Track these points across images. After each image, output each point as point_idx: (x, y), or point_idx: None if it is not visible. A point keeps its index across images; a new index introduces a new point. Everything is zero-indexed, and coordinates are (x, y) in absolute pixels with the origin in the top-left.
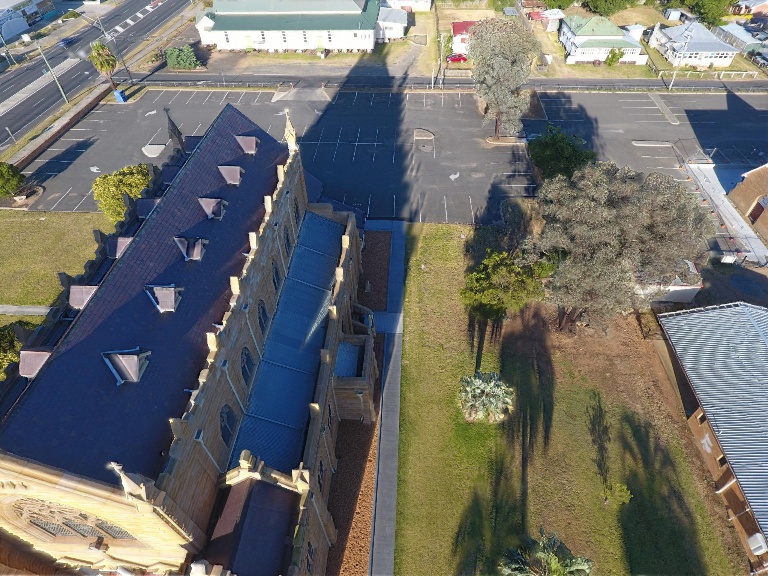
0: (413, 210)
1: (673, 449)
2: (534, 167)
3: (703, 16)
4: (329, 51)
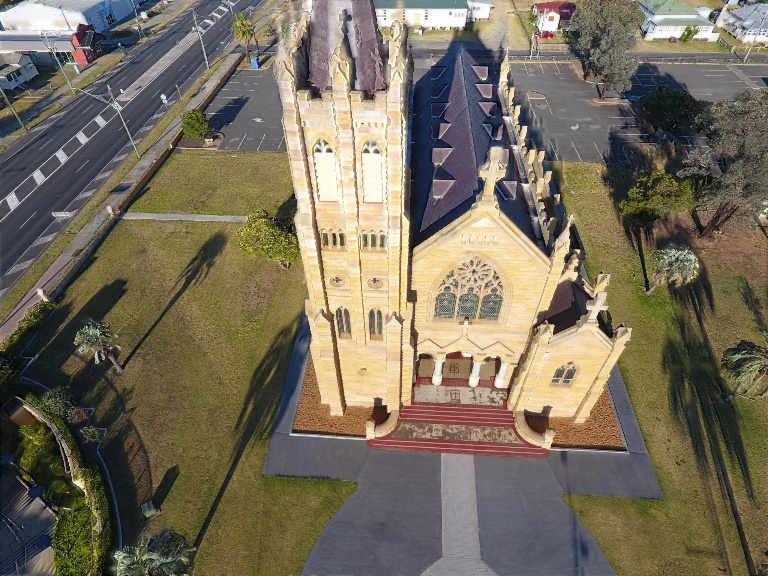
0: (549, 152)
1: None
2: (643, 121)
3: (763, 0)
4: (423, 29)
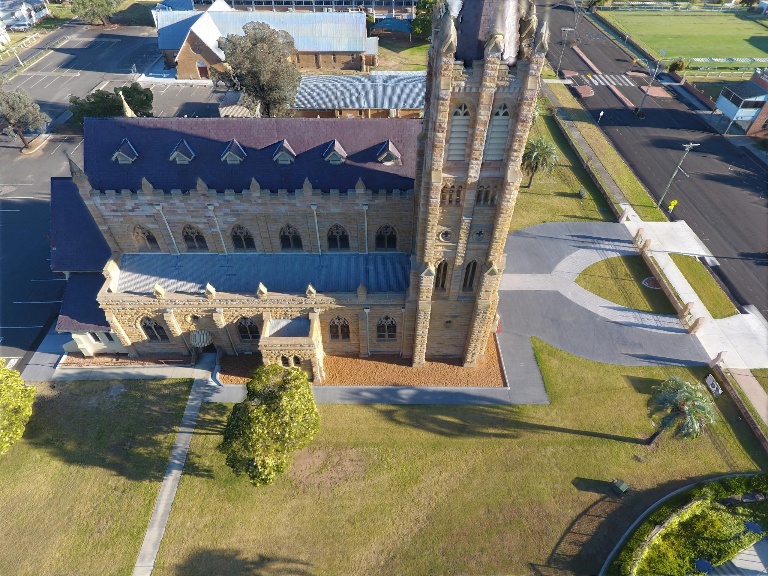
0: None
1: None
2: None
3: None
4: None
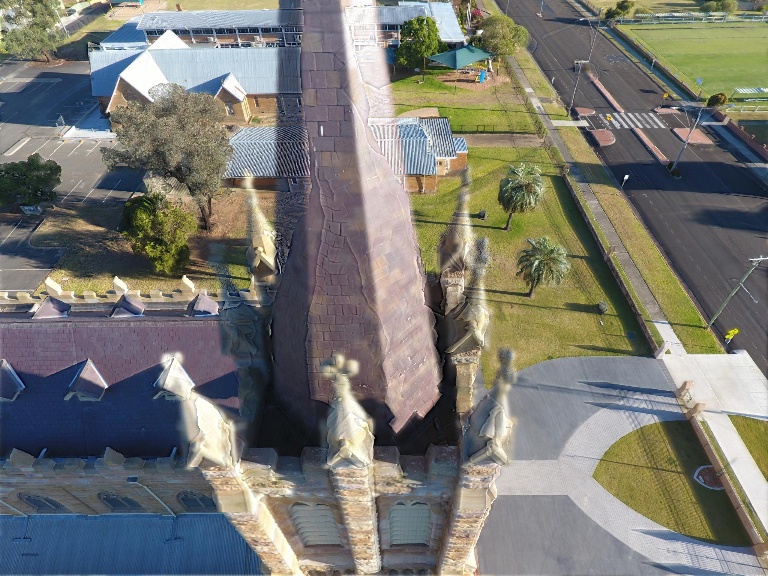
0: None
1: (307, 201)
2: None
3: None
4: None
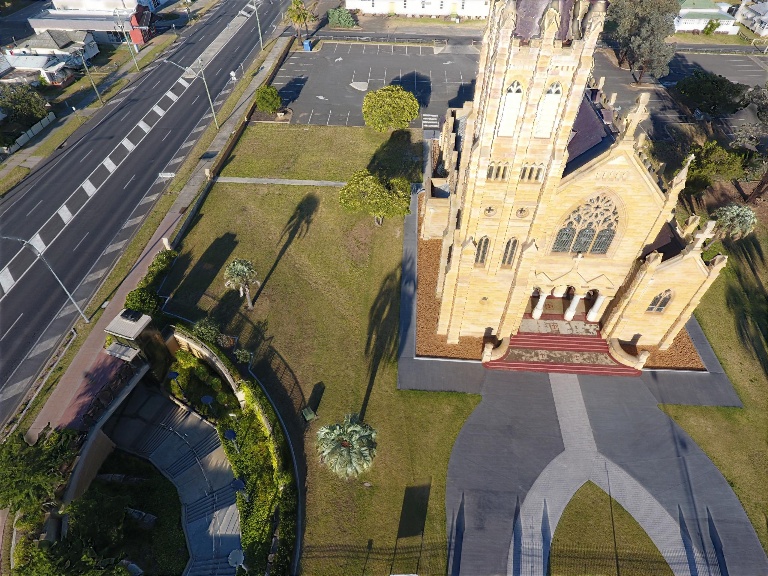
0: None
1: None
2: (679, 104)
3: None
4: (459, 17)
